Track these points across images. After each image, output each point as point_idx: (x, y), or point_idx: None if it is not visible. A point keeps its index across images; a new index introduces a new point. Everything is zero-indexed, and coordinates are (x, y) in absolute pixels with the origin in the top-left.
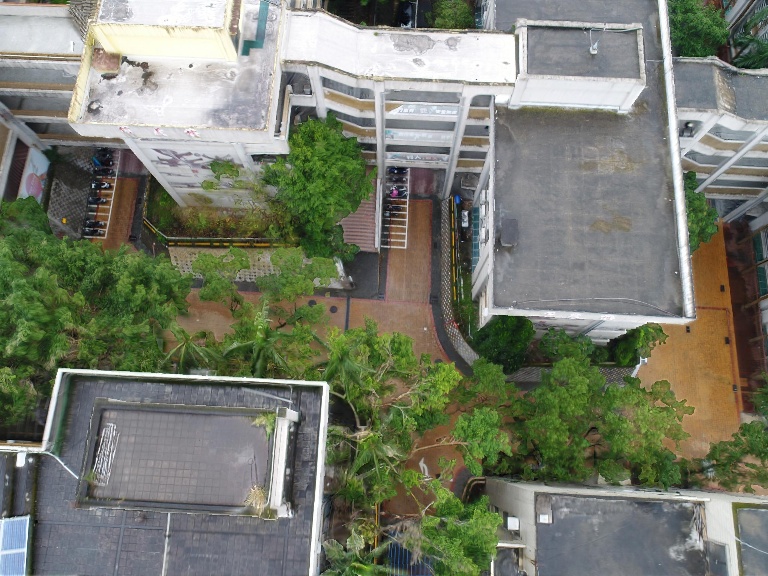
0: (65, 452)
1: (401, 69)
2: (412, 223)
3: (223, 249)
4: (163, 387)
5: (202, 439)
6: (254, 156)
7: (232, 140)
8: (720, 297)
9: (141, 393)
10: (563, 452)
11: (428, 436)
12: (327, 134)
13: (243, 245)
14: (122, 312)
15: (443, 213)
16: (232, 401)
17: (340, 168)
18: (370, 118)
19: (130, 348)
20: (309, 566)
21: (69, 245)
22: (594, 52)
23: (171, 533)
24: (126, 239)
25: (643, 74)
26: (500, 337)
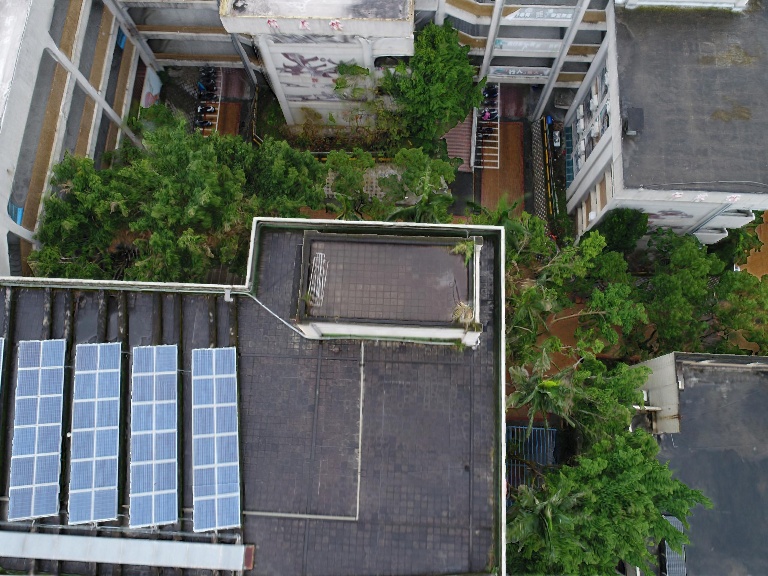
0: (261, 294)
1: None
2: (504, 144)
3: None
4: None
5: (405, 266)
6: (376, 61)
7: (371, 33)
8: None
9: None
10: (681, 335)
11: None
12: (448, 37)
13: None
14: (273, 195)
15: (534, 134)
16: None
17: (457, 73)
18: (485, 25)
19: None
20: (497, 389)
21: None
22: None
23: (365, 363)
24: None
25: None
26: (616, 230)
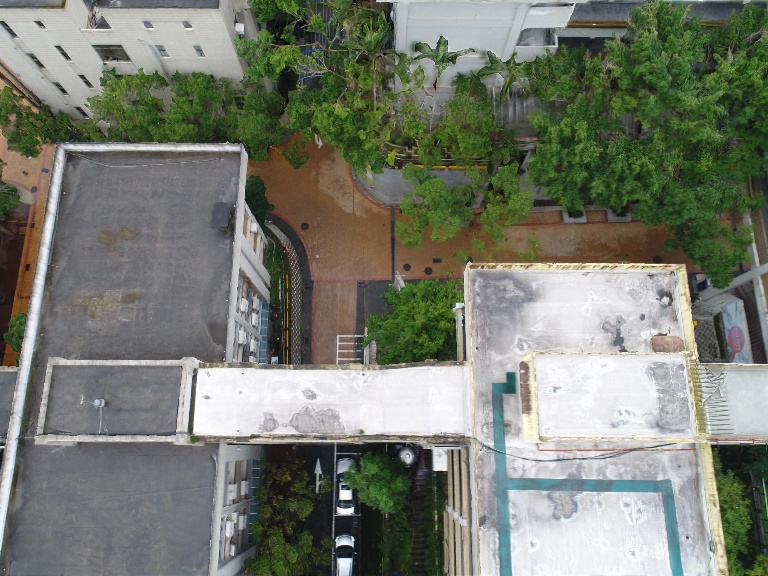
0: None
1: (330, 384)
2: None
3: None
4: None
5: None
6: None
7: None
8: (23, 309)
9: None
10: None
11: (315, 165)
12: None
13: None
14: (580, 120)
15: None
16: None
17: None
18: None
19: None
20: None
21: (668, 247)
22: None
23: None
24: None
25: (49, 372)
26: None
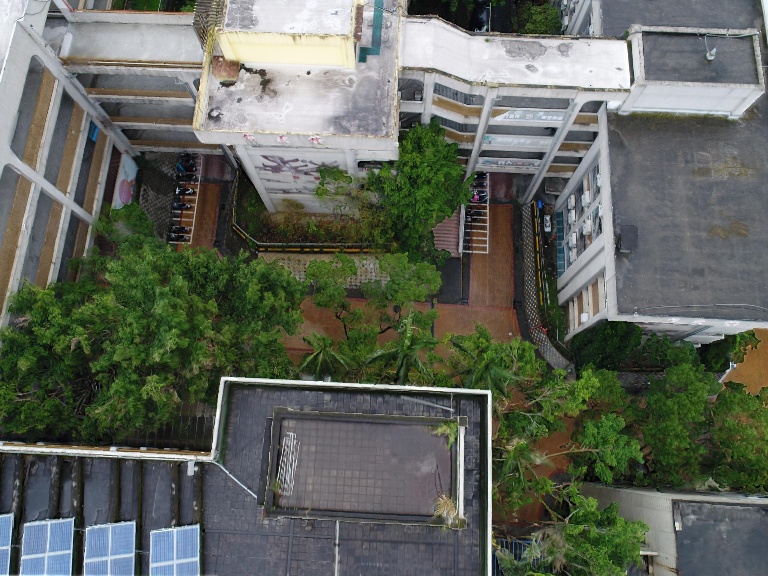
0: (228, 461)
1: (514, 75)
2: (493, 228)
3: (313, 255)
4: (322, 395)
5: (383, 448)
6: (360, 162)
7: (353, 147)
8: None
9: (300, 401)
10: (678, 458)
11: None
12: (435, 140)
13: (333, 251)
14: (248, 319)
15: (524, 218)
16: (392, 409)
17: (444, 174)
18: (473, 124)
19: (260, 355)
20: (482, 575)
21: None
22: (711, 58)
23: (340, 542)
24: (211, 245)
25: (762, 80)
26: (609, 343)
